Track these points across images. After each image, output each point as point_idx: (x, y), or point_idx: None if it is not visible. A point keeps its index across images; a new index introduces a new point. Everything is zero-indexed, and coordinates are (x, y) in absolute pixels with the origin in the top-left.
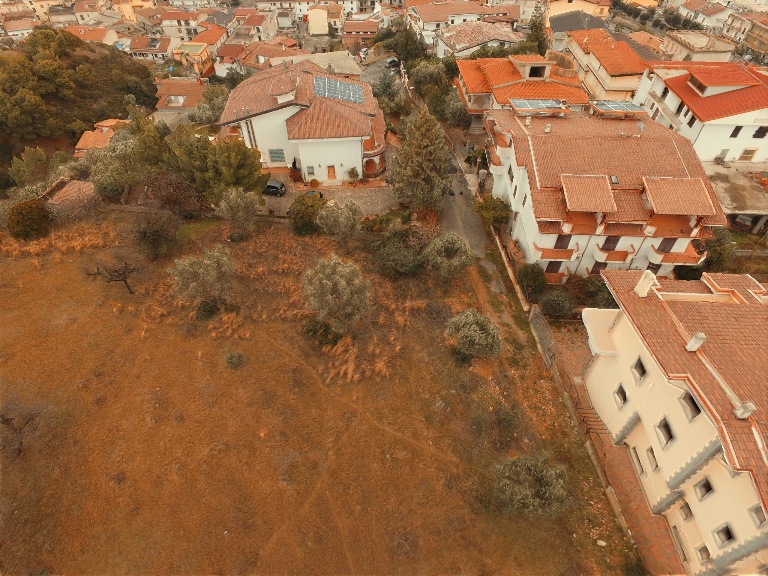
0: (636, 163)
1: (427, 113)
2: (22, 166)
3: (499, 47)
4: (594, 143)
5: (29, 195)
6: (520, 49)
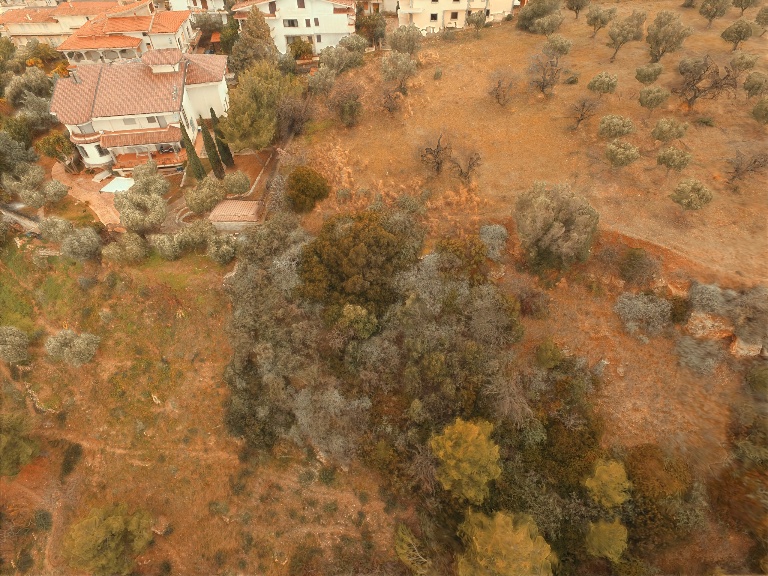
0: None
1: (256, 7)
2: None
3: None
4: None
5: (232, 240)
6: (6, 46)
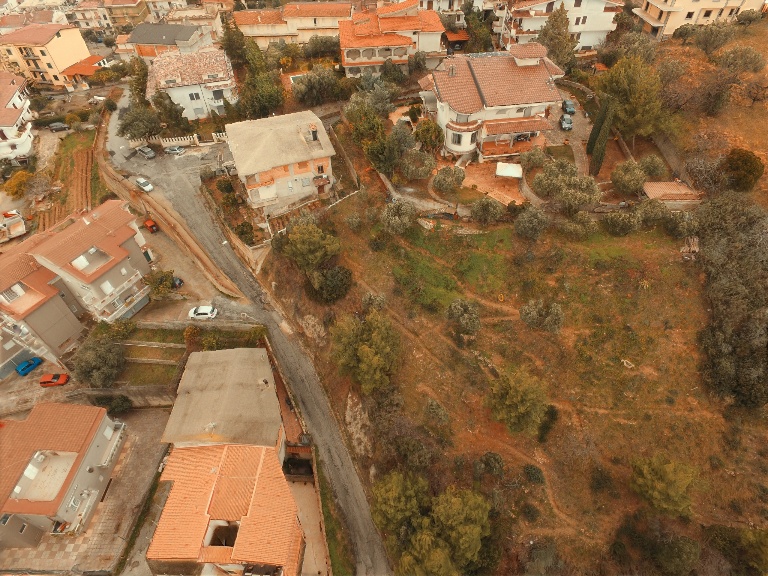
0: None
1: None
2: (469, 513)
3: (254, 51)
4: None
5: (694, 217)
6: None
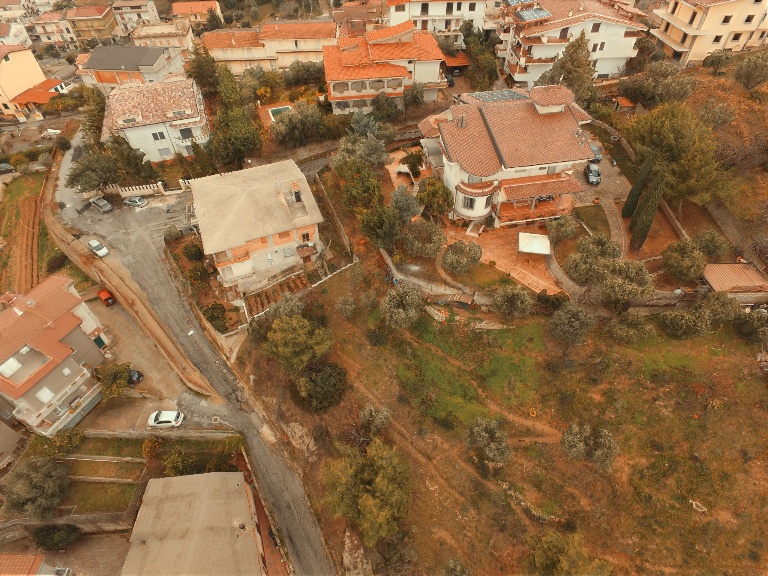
0: (590, 1)
1: None
2: None
3: (227, 82)
4: (584, 3)
5: None
6: None
